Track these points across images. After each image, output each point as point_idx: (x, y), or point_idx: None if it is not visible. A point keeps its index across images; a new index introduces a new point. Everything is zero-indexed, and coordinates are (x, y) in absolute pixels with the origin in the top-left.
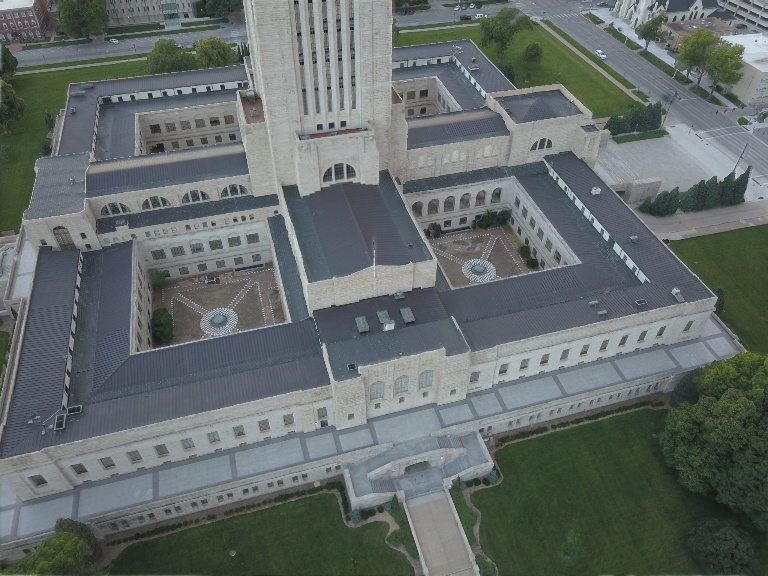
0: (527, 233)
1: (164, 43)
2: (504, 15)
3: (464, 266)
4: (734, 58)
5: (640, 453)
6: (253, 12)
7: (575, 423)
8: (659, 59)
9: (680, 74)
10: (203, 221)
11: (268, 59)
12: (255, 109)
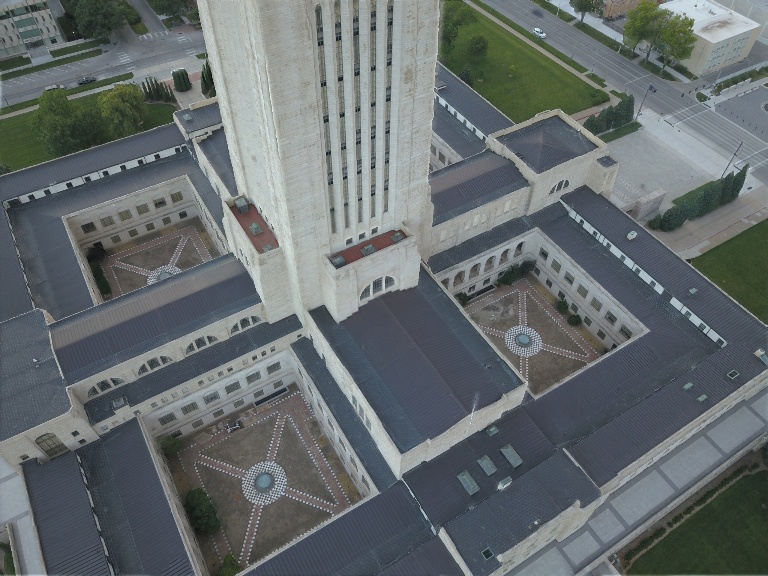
0: (562, 287)
1: (51, 97)
2: (446, 10)
3: (506, 339)
4: (687, 33)
5: (759, 532)
6: (277, 146)
7: (688, 514)
8: (597, 31)
9: (624, 47)
10: (218, 371)
11: (294, 191)
12: (257, 226)
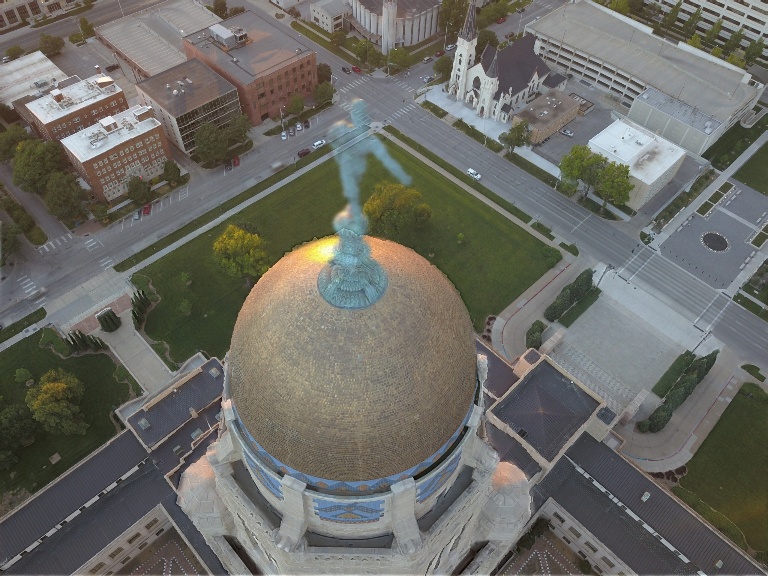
0: (583, 550)
1: None
2: None
3: None
4: (625, 182)
5: None
6: None
7: None
8: (529, 162)
9: (559, 181)
10: None
11: None
12: None
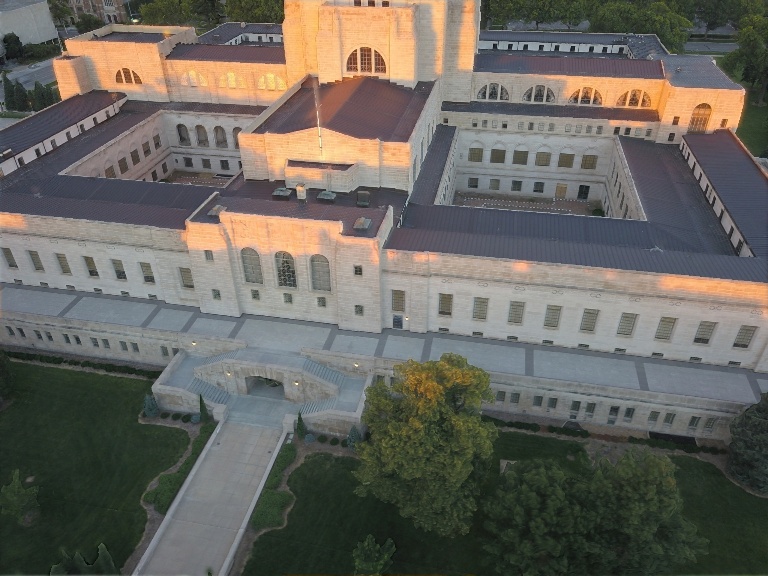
0: None
1: None
2: None
3: None
4: None
5: None
6: None
7: None
8: None
9: None
10: None
11: None
12: None
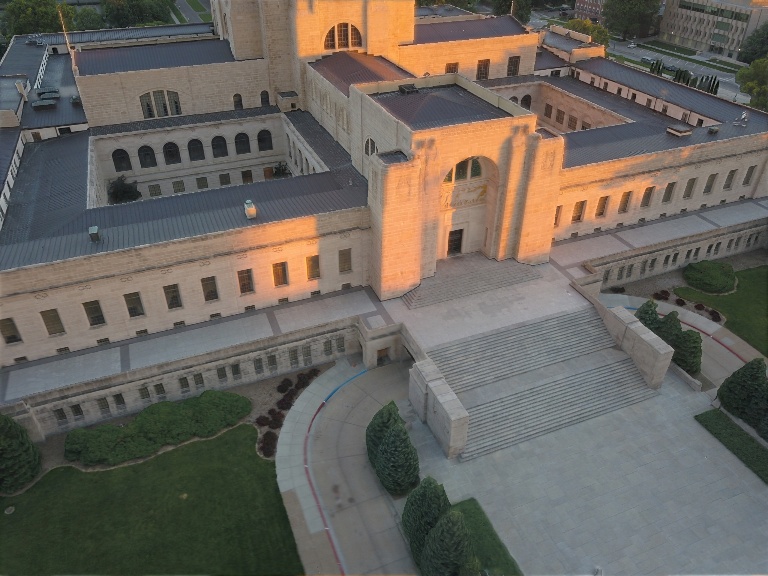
0: None
1: None
2: None
3: None
4: None
5: None
6: None
7: None
8: None
9: None
10: None
11: None
12: None
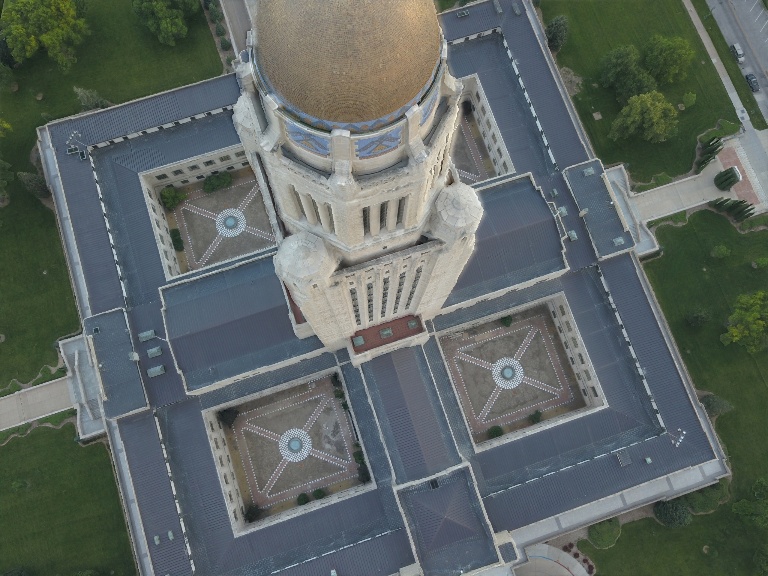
0: (329, 497)
1: (678, 48)
2: None
3: (300, 431)
4: None
5: (98, 556)
6: None
7: None
8: None
9: None
10: None
11: None
12: None
